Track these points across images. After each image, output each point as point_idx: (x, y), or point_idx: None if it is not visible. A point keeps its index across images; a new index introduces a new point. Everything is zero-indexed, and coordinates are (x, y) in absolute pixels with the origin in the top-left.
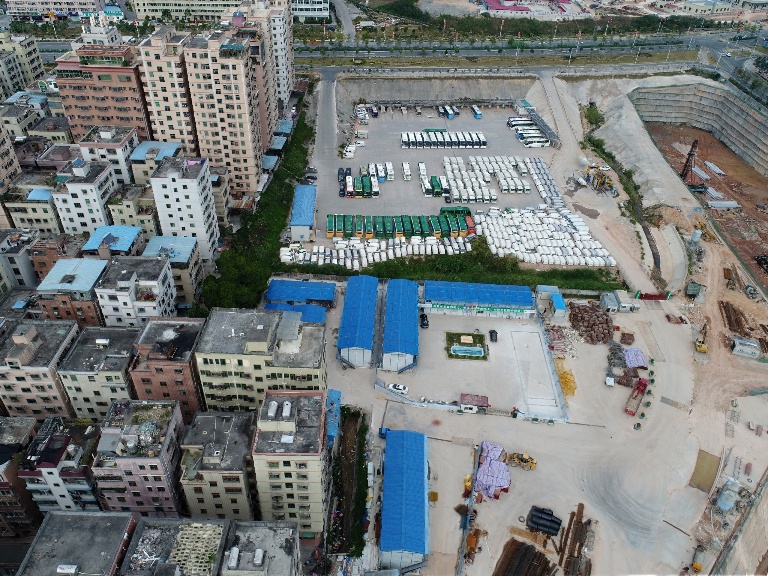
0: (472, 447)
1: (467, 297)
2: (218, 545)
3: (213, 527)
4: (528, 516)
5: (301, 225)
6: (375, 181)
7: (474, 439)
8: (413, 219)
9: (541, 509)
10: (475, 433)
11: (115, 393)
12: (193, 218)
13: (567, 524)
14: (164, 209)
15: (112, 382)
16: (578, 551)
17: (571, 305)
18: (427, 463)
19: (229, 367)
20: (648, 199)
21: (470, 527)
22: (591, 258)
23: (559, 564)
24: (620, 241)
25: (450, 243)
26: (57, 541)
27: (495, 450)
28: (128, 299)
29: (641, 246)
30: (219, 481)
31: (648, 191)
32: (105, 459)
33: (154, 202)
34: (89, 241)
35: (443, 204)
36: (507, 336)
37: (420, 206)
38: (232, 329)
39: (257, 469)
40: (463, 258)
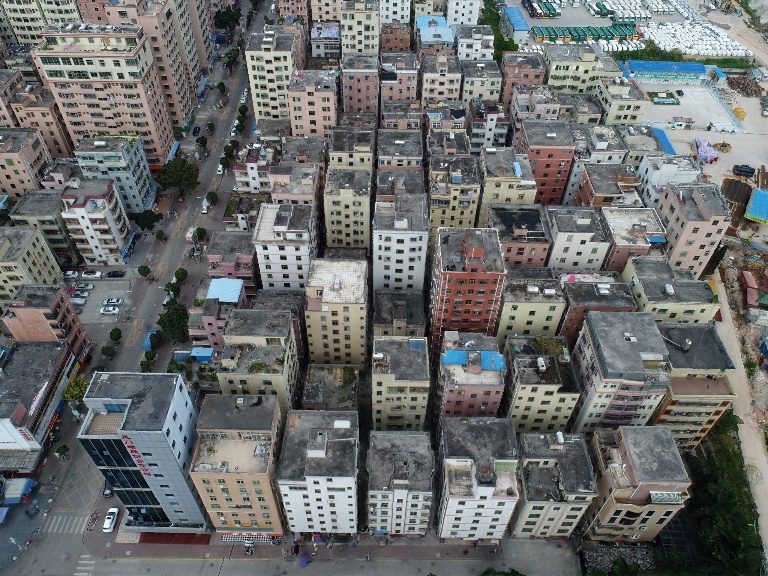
0: (687, 143)
1: (660, 68)
2: (614, 133)
3: (605, 128)
4: (734, 169)
5: (522, 30)
6: (556, 6)
7: (687, 140)
8: (597, 28)
9: (741, 165)
10: (686, 137)
11: (491, 95)
12: (471, 14)
13: (757, 173)
14: (453, 7)
15: (493, 86)
16: (767, 183)
17: (728, 77)
18: (670, 142)
19: (569, 72)
20: (765, 18)
21: (701, 173)
22: (735, 51)
23: (757, 187)
24: (751, 42)
25: (628, 43)
26: (534, 130)
27: (704, 142)
28: (480, 46)
29: (767, 45)
30: (585, 123)
31: (764, 12)
32: (522, 111)
33: (442, 3)
34: (419, 24)
35: (610, 22)
36: (688, 93)
37: (594, 23)
38: (568, 50)
39: (610, 112)
40: (641, 52)
